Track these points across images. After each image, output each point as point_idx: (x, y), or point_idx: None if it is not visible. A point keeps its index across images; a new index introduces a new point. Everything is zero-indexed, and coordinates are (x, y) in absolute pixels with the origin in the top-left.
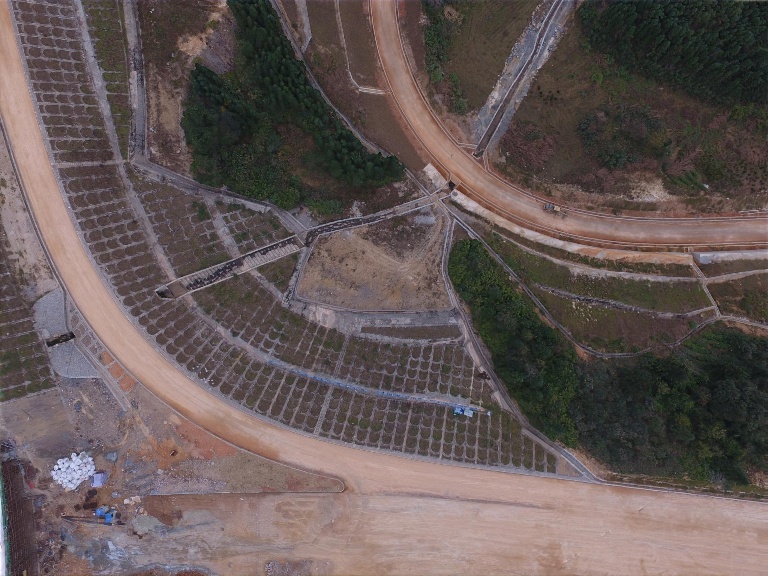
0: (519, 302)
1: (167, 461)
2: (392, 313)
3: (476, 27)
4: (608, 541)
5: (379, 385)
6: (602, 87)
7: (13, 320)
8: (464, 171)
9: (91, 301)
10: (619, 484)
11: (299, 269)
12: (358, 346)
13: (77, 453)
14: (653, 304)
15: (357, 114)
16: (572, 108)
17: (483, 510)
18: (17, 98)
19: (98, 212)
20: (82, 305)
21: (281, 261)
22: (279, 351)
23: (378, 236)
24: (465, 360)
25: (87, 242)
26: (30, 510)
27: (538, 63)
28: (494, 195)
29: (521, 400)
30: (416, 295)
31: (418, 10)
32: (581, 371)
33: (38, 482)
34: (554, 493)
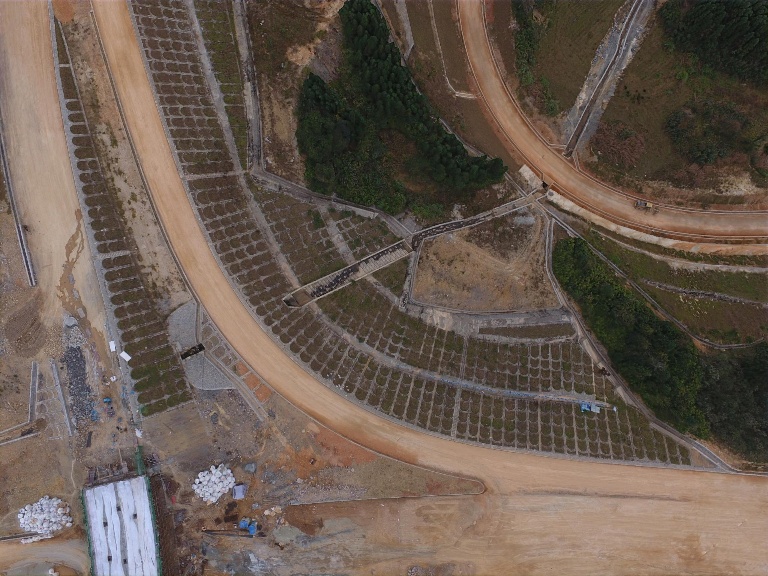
0: (631, 298)
1: (306, 470)
2: (503, 313)
3: (561, 30)
4: (745, 531)
5: (505, 385)
6: (687, 85)
7: (149, 334)
8: (556, 171)
9: (224, 312)
10: (754, 473)
11: (411, 273)
12: (478, 347)
13: (216, 466)
14: (756, 295)
15: (456, 118)
16: (659, 106)
17: (621, 505)
18: (144, 112)
19: (225, 223)
20: (215, 316)
21: (393, 266)
22: (404, 355)
23: (480, 238)
24: (583, 357)
25: (218, 253)
26: (171, 526)
27: (622, 63)
28: (586, 194)
29: (647, 394)
30: (525, 295)
31: (508, 15)
32: (705, 363)
33: (179, 497)
34: (690, 485)
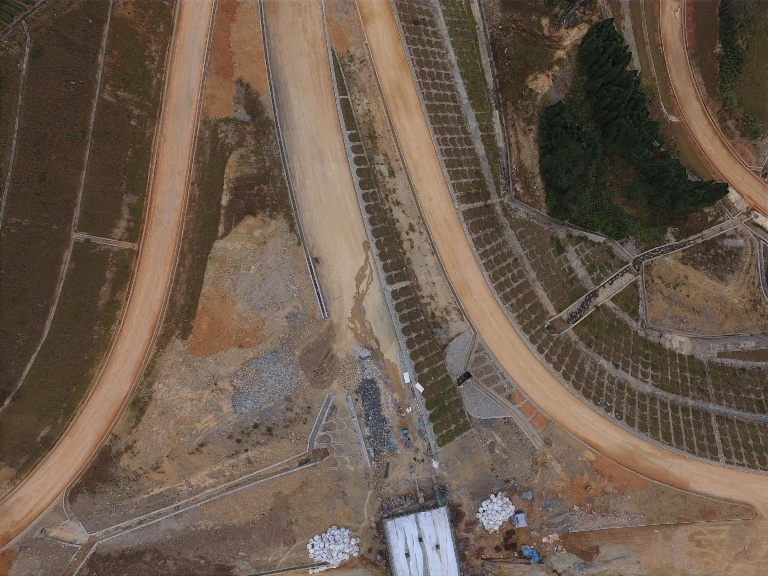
0: None
1: (581, 497)
2: (730, 337)
3: (758, 53)
4: None
5: (754, 410)
6: None
7: (433, 364)
8: (755, 193)
9: (500, 341)
10: None
11: (642, 297)
12: (719, 371)
13: (494, 494)
14: None
15: (673, 143)
16: None
17: None
18: (418, 143)
19: (493, 252)
20: (491, 345)
21: (626, 290)
22: (656, 381)
23: (695, 261)
24: None
25: (492, 283)
26: None
27: None
28: None
29: None
30: (748, 318)
31: (714, 39)
32: None
33: (464, 525)
34: None
